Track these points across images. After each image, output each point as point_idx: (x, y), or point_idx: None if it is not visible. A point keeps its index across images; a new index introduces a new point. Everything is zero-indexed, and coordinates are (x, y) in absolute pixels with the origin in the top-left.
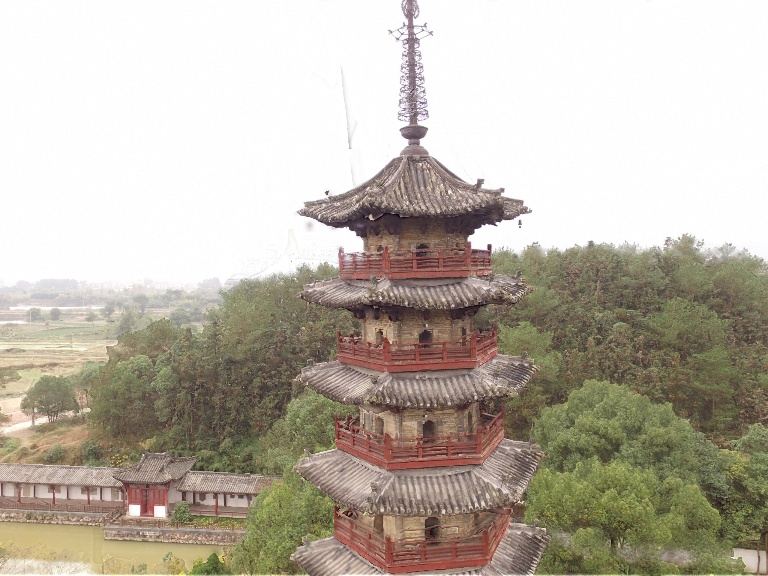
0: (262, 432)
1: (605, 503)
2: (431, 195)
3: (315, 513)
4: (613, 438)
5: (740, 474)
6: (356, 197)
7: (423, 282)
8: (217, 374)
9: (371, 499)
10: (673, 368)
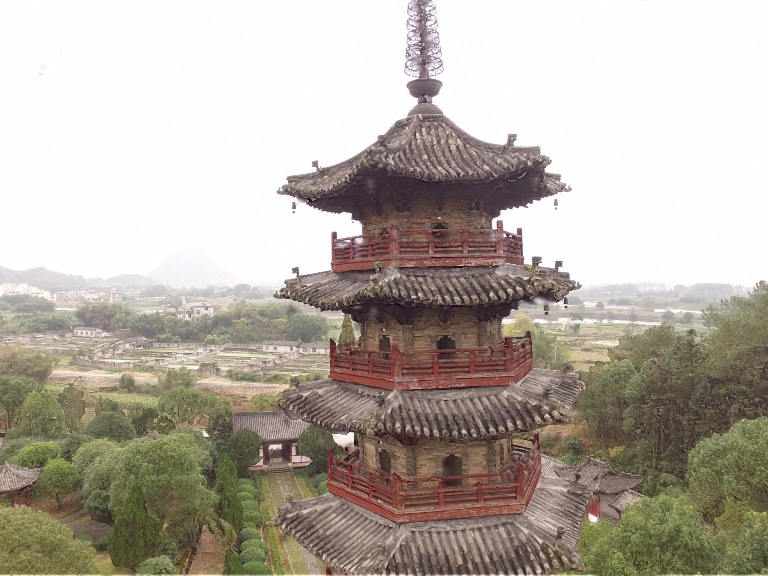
0: None
1: None
2: None
3: (606, 567)
4: None
5: None
6: None
7: (367, 275)
8: (693, 391)
9: (280, 510)
10: None
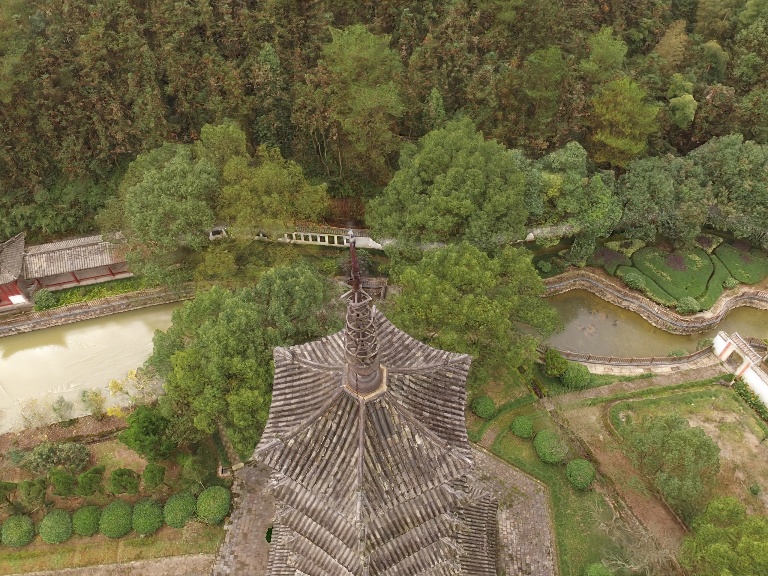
0: (80, 177)
1: (466, 313)
2: (401, 450)
3: (227, 370)
4: (464, 216)
5: (554, 195)
6: (310, 432)
7: None
8: None
9: None
10: (509, 72)
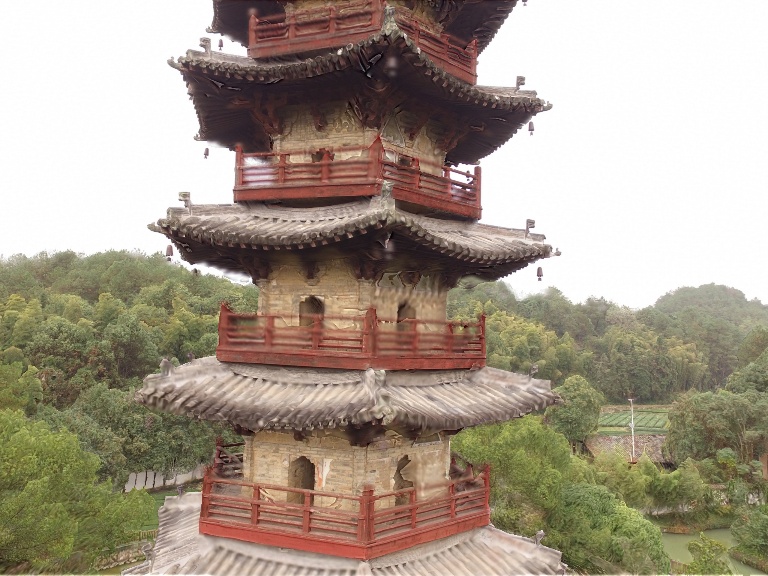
0: None
1: (36, 442)
2: None
3: None
4: None
5: None
6: None
7: None
8: None
9: None
10: None
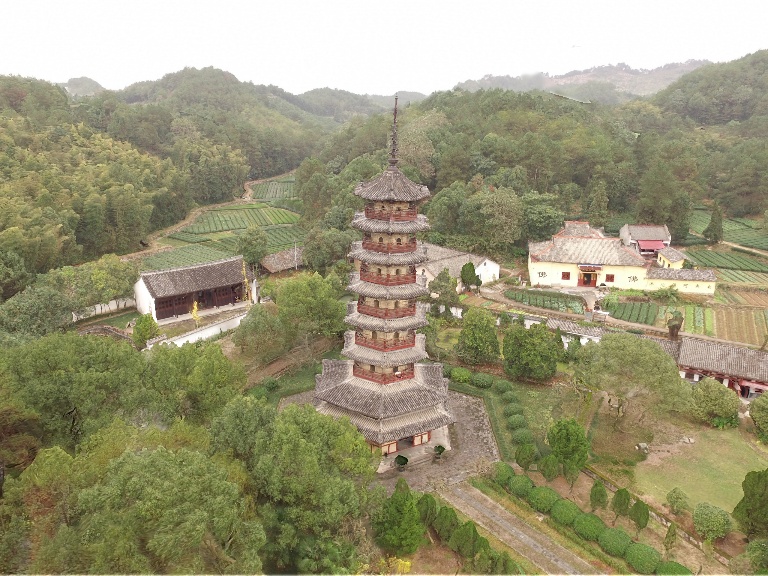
0: None
1: None
2: None
3: None
4: None
5: None
6: None
7: None
8: None
9: None
10: None
